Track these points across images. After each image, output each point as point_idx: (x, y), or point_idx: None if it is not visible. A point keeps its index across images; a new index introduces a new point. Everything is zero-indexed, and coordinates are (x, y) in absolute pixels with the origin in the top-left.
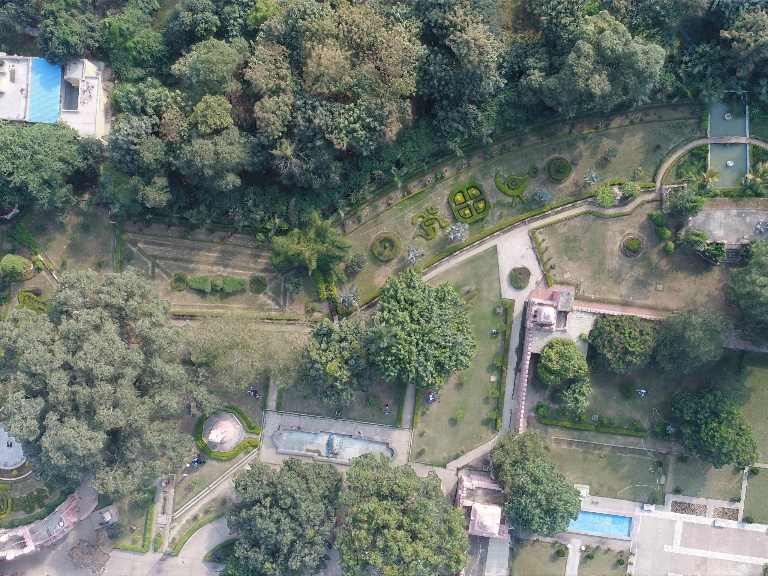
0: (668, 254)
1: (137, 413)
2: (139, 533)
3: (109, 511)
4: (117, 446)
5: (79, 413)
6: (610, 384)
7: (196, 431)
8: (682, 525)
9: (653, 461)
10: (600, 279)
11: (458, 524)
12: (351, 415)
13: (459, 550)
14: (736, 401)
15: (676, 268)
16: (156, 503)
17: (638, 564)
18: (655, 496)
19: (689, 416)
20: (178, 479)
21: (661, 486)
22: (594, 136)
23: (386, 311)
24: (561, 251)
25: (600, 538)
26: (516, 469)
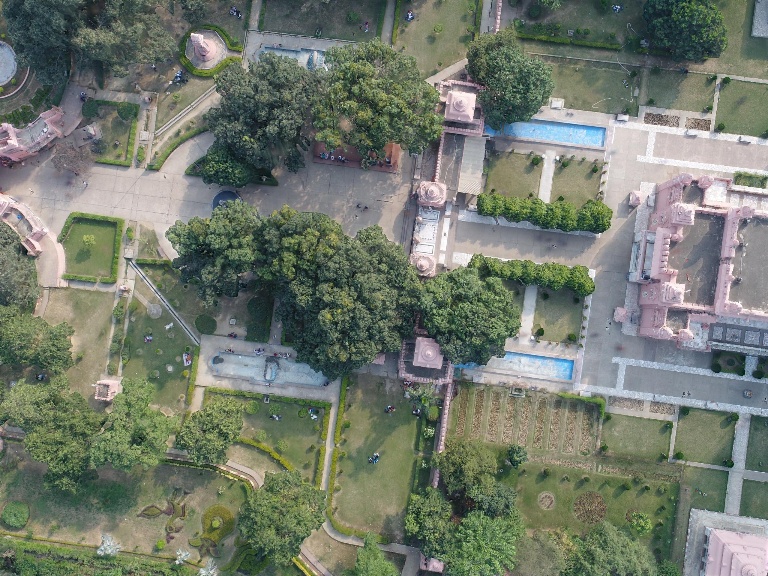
0: None
1: None
2: (122, 149)
3: (93, 127)
4: (100, 14)
5: None
6: (585, 0)
7: (179, 48)
8: (655, 136)
9: (627, 74)
10: None
11: None
12: (331, 34)
13: None
14: None
15: None
16: (139, 120)
17: (611, 174)
18: None
19: (661, 5)
20: (161, 98)
21: (635, 99)
22: None
23: None
24: None
25: (574, 149)
26: (491, 53)
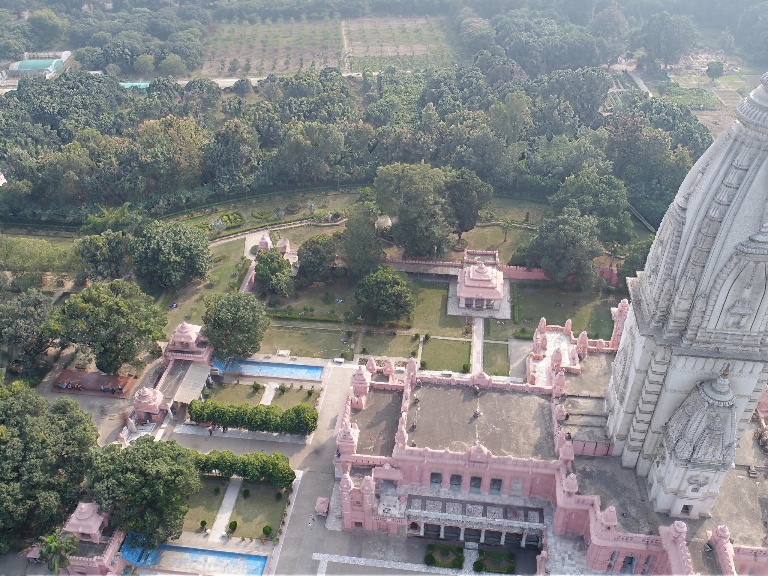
0: None
1: None
2: None
3: None
4: None
5: None
6: (316, 297)
7: None
8: None
9: (345, 336)
10: None
11: None
12: None
13: None
14: None
15: None
16: None
17: (326, 398)
18: None
19: None
20: None
21: (351, 350)
22: (318, 198)
23: None
24: (290, 240)
25: (295, 381)
26: None
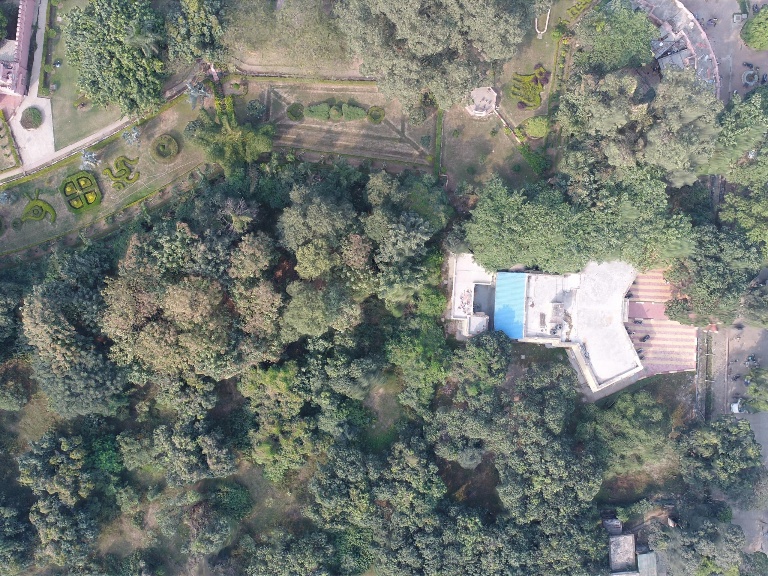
0: None
1: None
2: None
3: None
4: None
5: None
6: None
7: None
8: None
9: None
10: None
11: None
12: None
13: None
14: None
15: None
16: None
17: None
18: None
19: None
20: None
21: None
22: None
23: (148, 70)
24: None
25: None
26: None
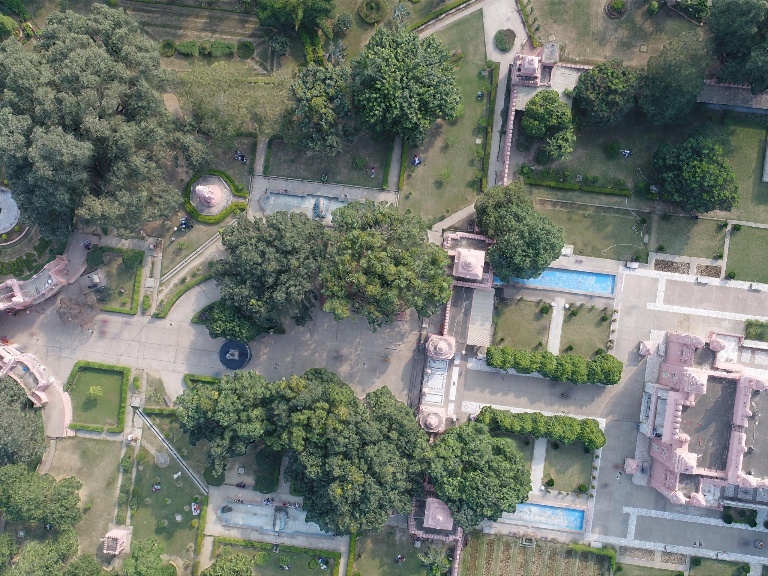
0: (652, 15)
1: (123, 131)
2: (127, 297)
3: (97, 275)
4: (104, 180)
5: (66, 131)
6: (594, 145)
7: (184, 195)
8: (665, 283)
9: (637, 220)
10: (585, 41)
11: (441, 255)
12: (337, 178)
13: (442, 281)
14: (718, 145)
15: (660, 29)
16: (144, 267)
17: (621, 322)
18: (638, 255)
19: (671, 160)
20: (166, 244)
21: (644, 245)
22: None
23: None
24: (546, 14)
25: (584, 296)
26: (500, 211)
